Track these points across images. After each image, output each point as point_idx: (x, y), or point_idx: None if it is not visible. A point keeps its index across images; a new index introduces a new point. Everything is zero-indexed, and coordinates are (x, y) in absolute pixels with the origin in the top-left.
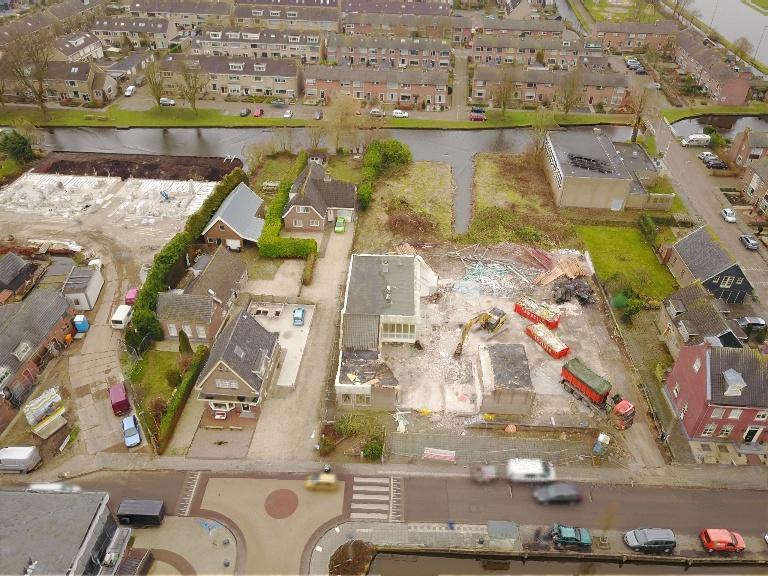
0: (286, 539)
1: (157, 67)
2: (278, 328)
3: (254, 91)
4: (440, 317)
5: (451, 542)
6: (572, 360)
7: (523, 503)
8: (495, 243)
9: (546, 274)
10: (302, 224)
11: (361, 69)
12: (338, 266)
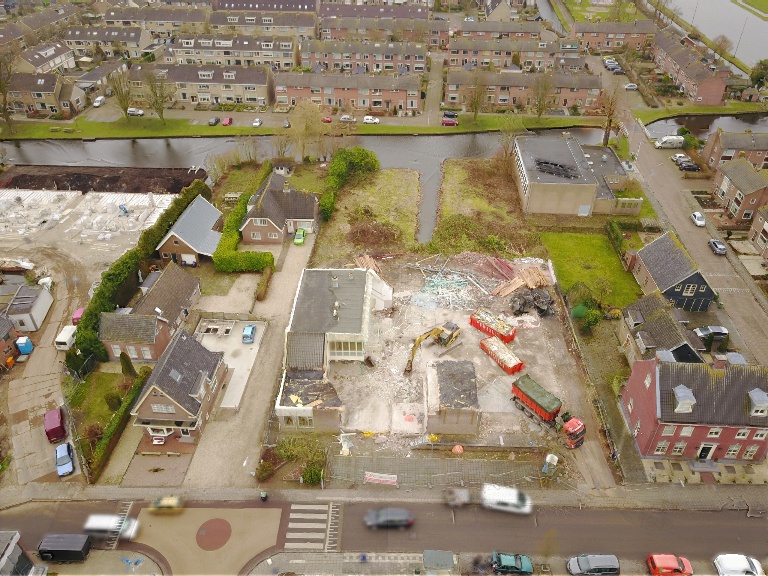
0: (215, 573)
1: (123, 77)
2: (227, 346)
3: (224, 99)
4: (394, 332)
5: (387, 573)
6: (522, 376)
7: (465, 529)
8: (457, 253)
9: (506, 285)
10: (260, 237)
11: (332, 75)
12: (295, 280)
